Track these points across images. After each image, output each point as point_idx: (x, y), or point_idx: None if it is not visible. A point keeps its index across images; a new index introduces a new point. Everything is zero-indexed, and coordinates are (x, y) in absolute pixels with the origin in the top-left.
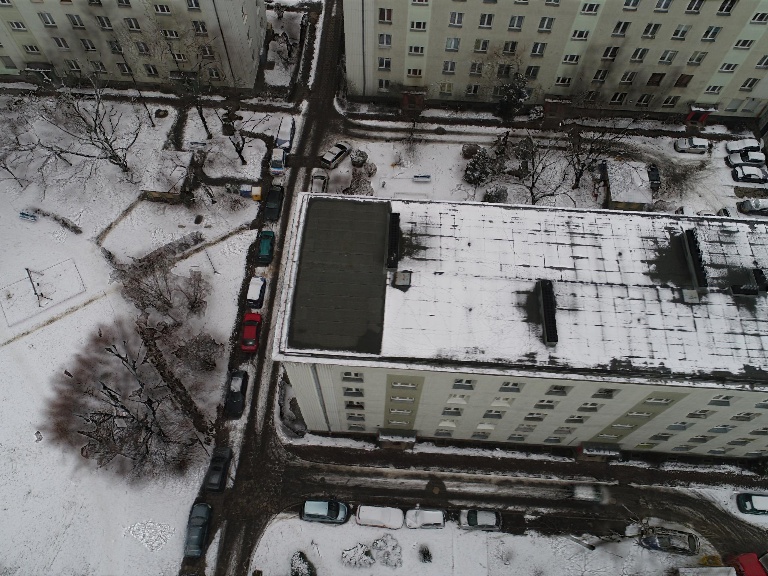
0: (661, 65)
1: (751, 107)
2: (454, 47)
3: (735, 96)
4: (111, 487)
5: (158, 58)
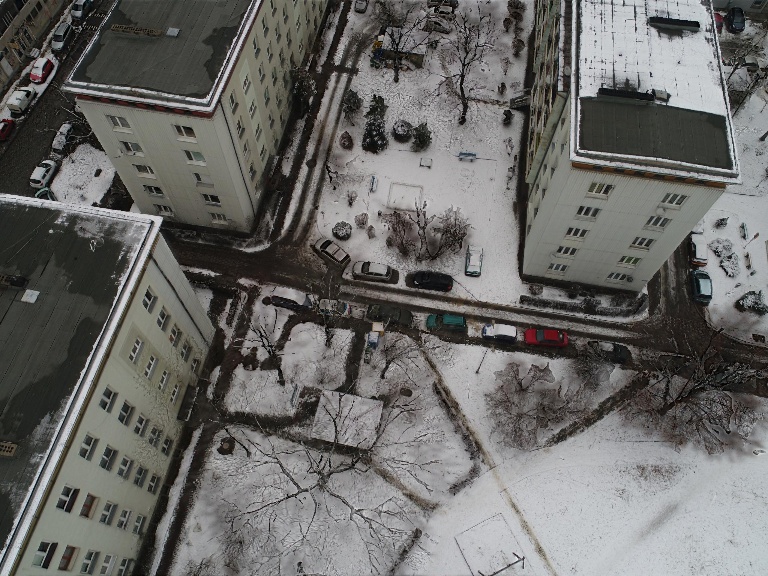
0: None
1: None
2: (265, 99)
3: None
4: (711, 460)
5: (166, 423)
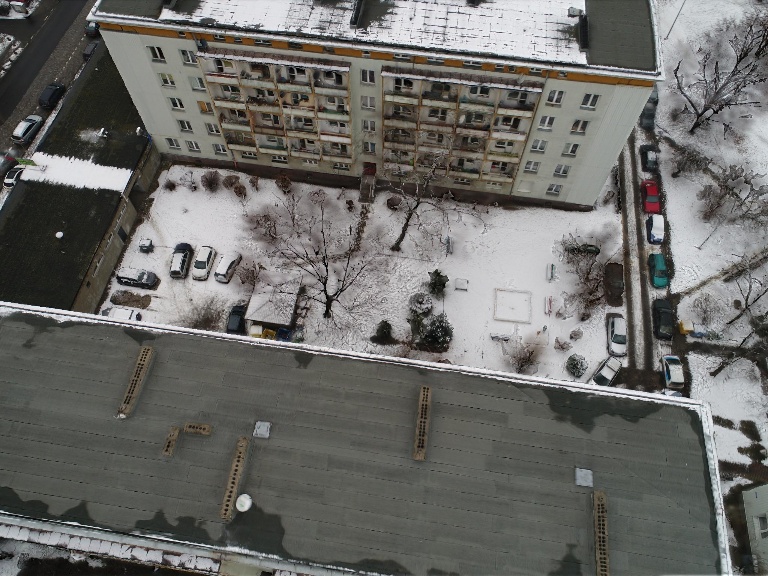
0: None
1: None
2: None
3: None
4: None
5: None
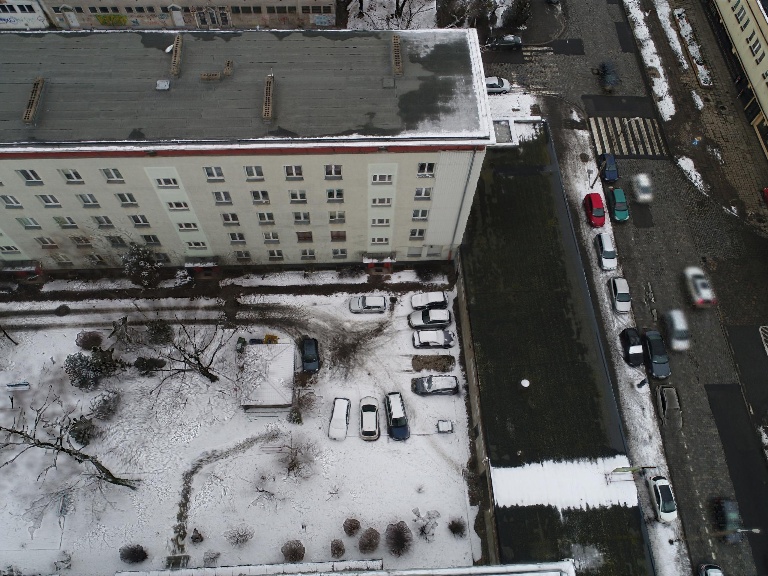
0: (299, 225)
1: (437, 251)
2: (36, 224)
3: (409, 244)
4: None
5: None
